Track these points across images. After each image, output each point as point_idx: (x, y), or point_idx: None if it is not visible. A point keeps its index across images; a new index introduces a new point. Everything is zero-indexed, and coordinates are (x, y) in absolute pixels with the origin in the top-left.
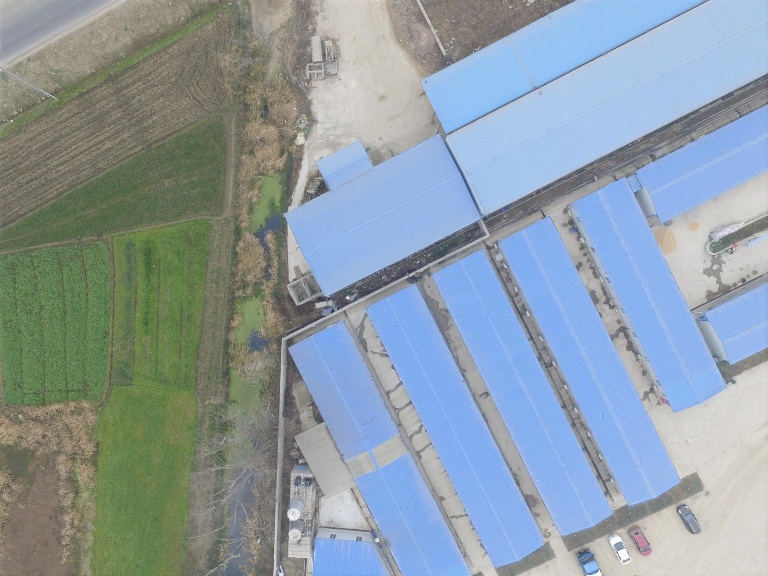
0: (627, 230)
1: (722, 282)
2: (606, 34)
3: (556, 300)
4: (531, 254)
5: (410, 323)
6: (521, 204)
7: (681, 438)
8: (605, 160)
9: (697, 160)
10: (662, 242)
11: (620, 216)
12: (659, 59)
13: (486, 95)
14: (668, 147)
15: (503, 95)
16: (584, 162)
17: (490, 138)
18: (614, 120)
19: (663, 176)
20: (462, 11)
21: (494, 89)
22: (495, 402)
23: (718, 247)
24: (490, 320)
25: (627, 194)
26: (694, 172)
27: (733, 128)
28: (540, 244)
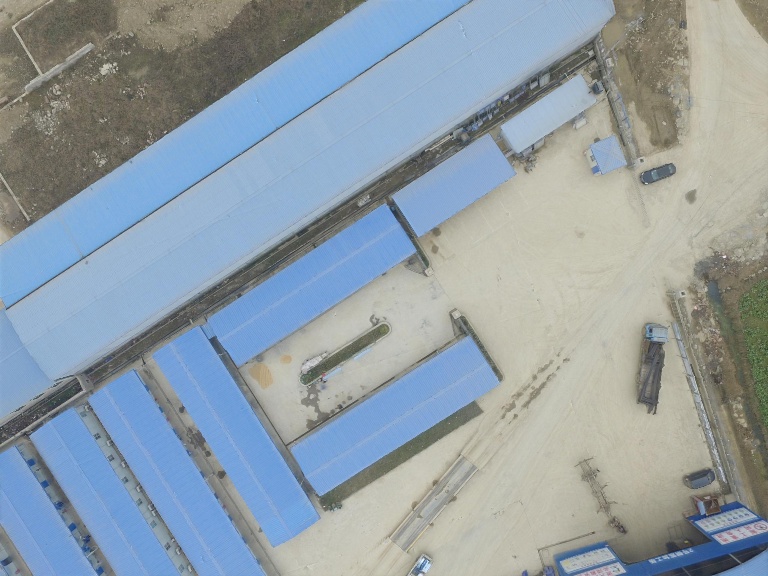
0: (203, 377)
1: (320, 410)
2: (144, 200)
3: (143, 451)
4: (115, 409)
5: (10, 486)
6: (123, 353)
7: (301, 565)
8: (195, 304)
9: (260, 304)
10: (259, 377)
11: (195, 364)
12: (190, 221)
13: (40, 268)
14: (253, 286)
15: (56, 266)
16: (136, 324)
17: (44, 310)
18: (156, 282)
19: (230, 323)
20: (40, 178)
21: (47, 261)
22: (103, 553)
23: (308, 379)
24: (84, 476)
25: (201, 342)
26: (257, 317)
27: (291, 270)
28: (124, 398)
